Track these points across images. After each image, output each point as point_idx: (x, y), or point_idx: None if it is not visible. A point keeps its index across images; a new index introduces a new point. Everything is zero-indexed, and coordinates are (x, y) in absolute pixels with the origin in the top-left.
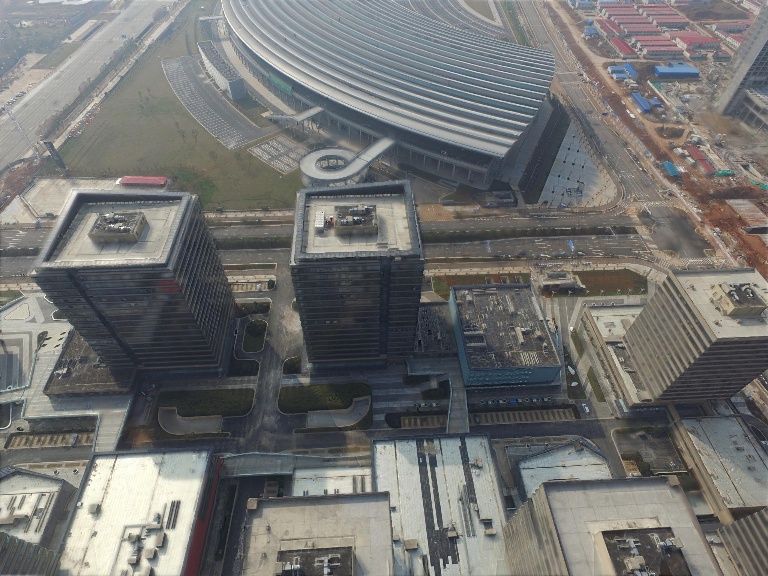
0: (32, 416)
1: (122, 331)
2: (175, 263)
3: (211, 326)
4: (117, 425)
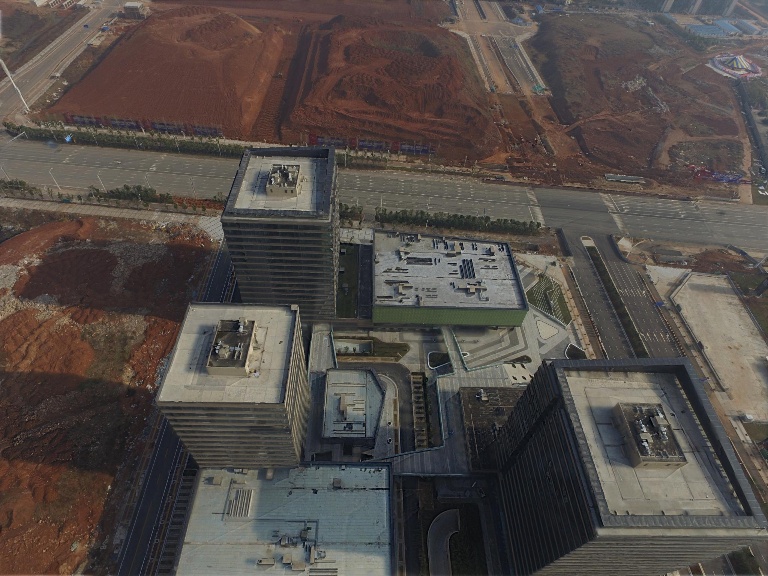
0: (438, 385)
1: (523, 458)
2: (613, 538)
3: (564, 571)
4: (433, 469)
